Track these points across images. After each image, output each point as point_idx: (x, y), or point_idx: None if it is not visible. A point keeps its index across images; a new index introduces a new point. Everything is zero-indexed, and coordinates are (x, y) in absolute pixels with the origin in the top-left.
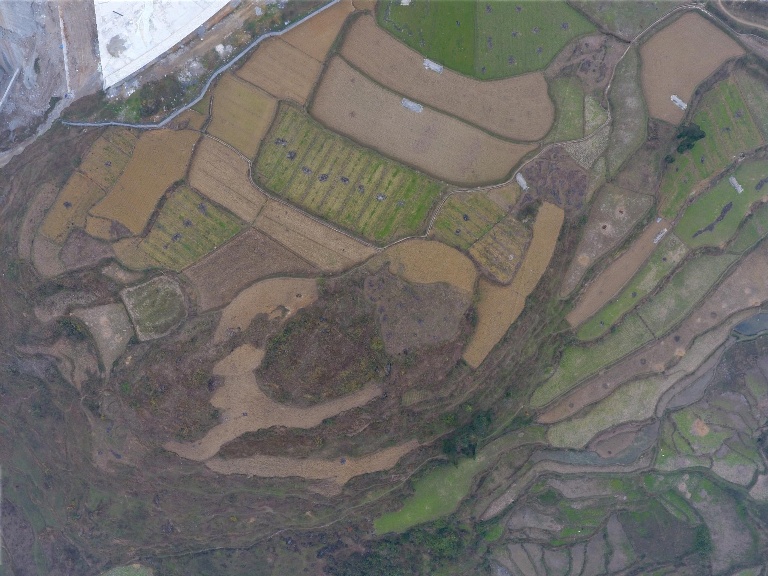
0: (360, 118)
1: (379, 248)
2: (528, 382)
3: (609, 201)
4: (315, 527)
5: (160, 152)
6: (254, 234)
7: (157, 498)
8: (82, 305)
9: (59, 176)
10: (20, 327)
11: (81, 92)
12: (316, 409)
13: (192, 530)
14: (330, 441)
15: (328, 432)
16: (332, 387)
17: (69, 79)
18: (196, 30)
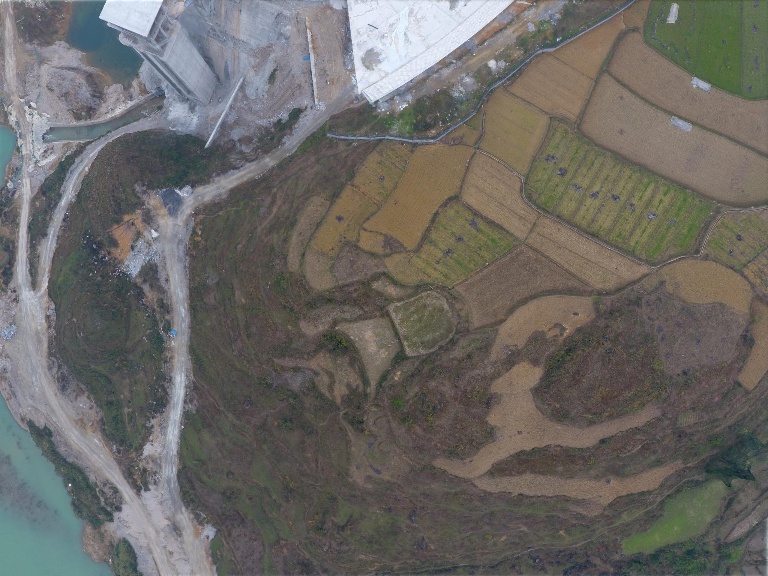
0: (629, 136)
1: (652, 267)
2: None
3: None
4: (567, 546)
5: (434, 167)
6: (526, 251)
7: (414, 514)
8: (348, 319)
9: (329, 189)
10: (284, 340)
11: (332, 104)
12: (593, 429)
13: (446, 547)
14: (599, 461)
15: (602, 452)
16: (614, 407)
17: (317, 91)
18: (463, 45)
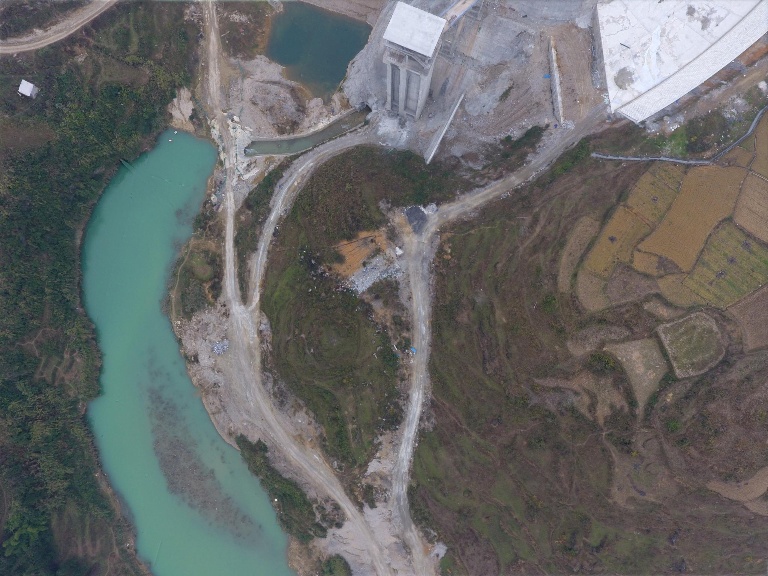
0: None
1: None
2: None
3: None
4: None
5: (708, 188)
6: None
7: (675, 536)
8: (616, 340)
9: (599, 210)
10: (550, 360)
11: (582, 123)
12: None
13: (704, 569)
14: None
15: None
16: None
17: (562, 109)
18: (727, 66)
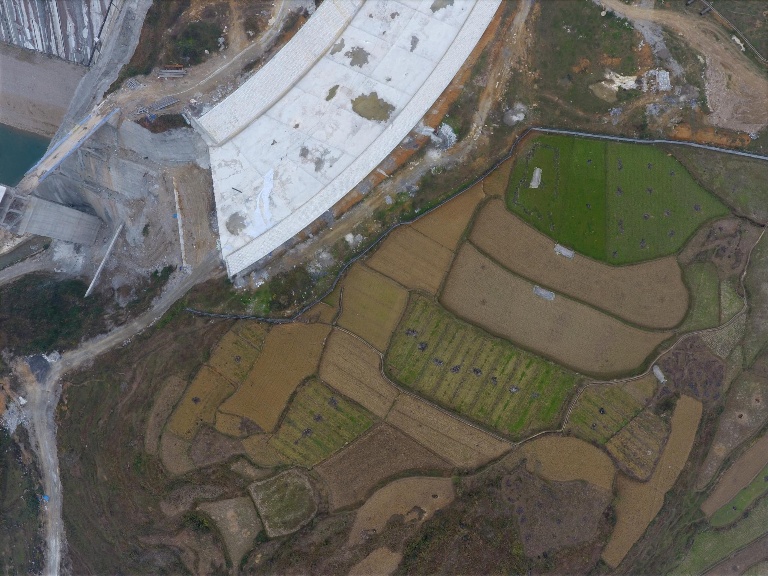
0: (491, 306)
1: (514, 443)
2: (660, 571)
3: (745, 389)
4: None
5: (291, 346)
6: (386, 429)
7: None
8: (209, 499)
9: (186, 369)
10: (145, 521)
11: (198, 269)
12: None
13: None
14: None
15: None
16: None
17: (184, 253)
18: (322, 215)
